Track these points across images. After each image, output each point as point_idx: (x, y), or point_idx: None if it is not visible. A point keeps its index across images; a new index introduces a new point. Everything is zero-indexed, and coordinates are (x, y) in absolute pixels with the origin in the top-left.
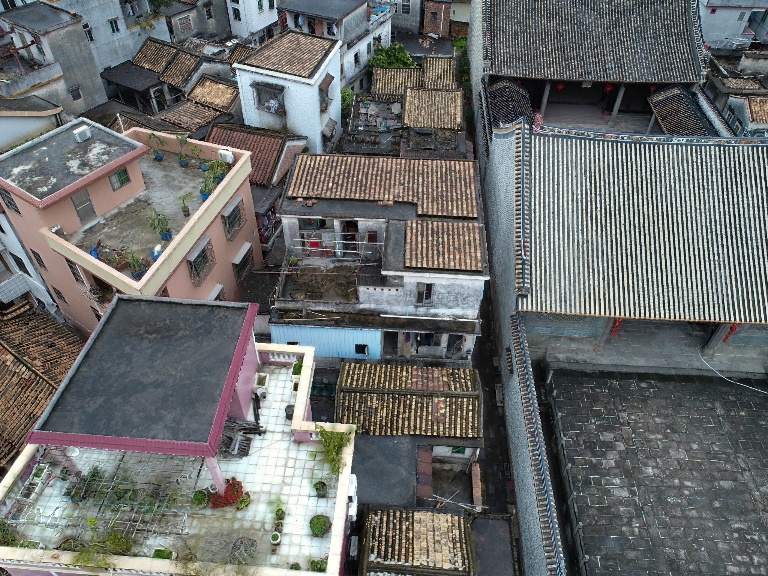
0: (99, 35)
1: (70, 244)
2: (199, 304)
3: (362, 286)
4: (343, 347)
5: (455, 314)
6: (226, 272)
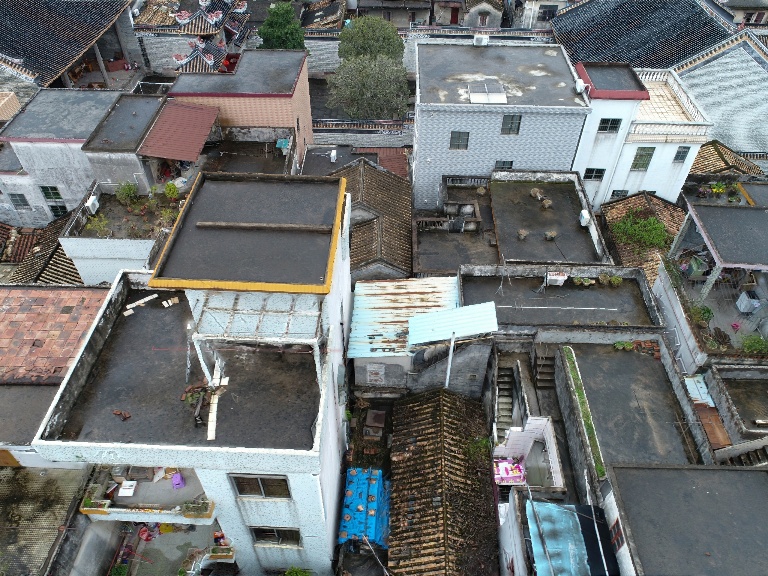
0: None
1: None
2: None
3: None
4: None
5: None
6: None
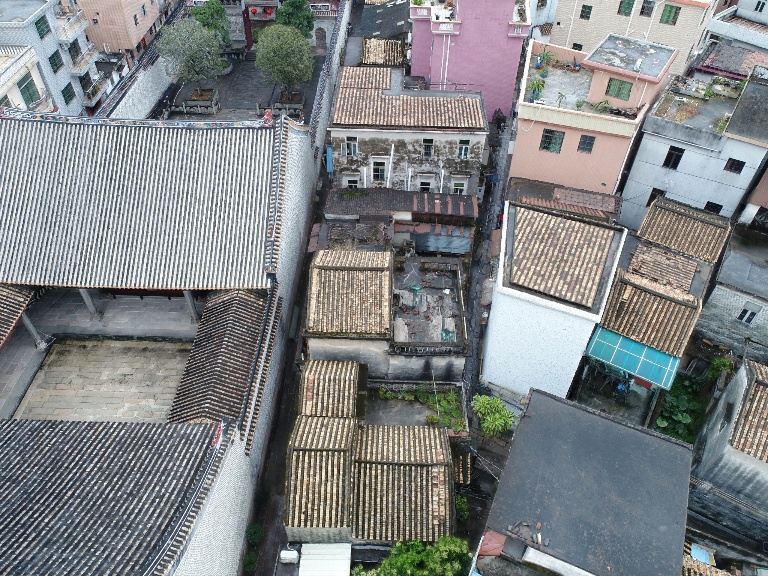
0: None
1: None
2: None
3: None
4: None
5: None
6: None
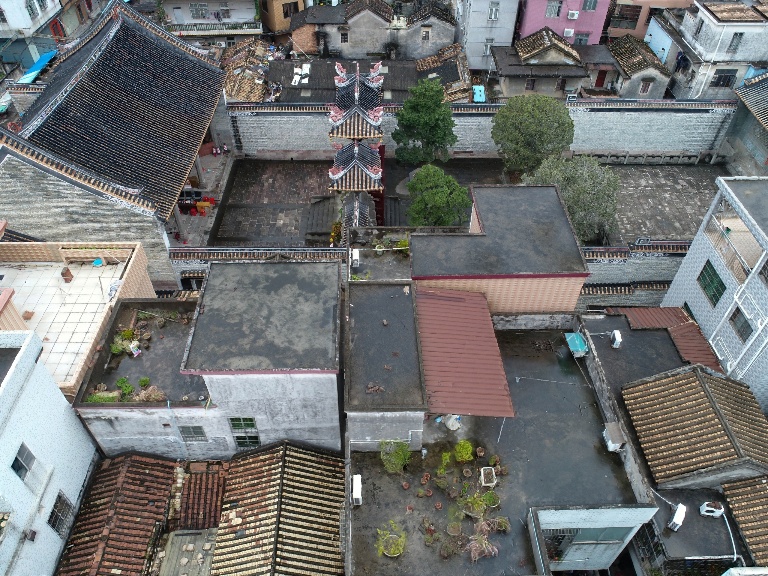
0: None
1: None
2: None
3: (687, 11)
4: (659, 48)
5: (700, 52)
6: None
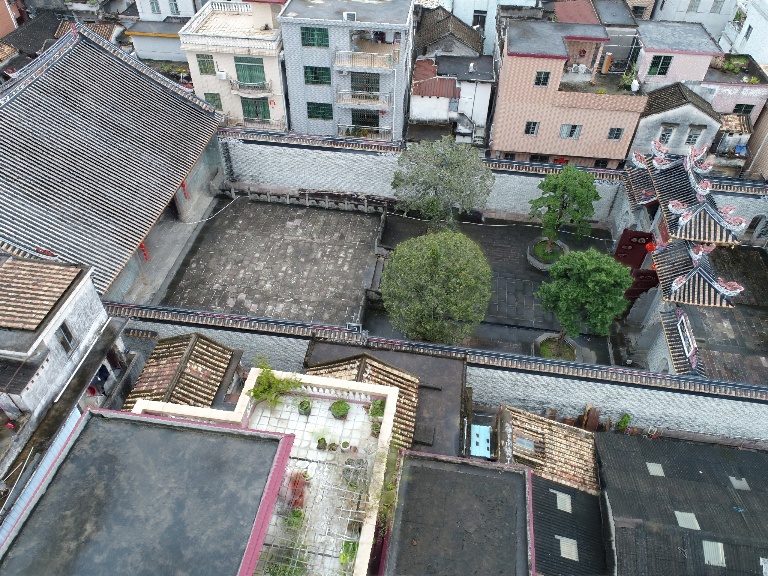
0: None
1: None
2: (55, 473)
3: (22, 392)
4: None
5: (95, 331)
6: None
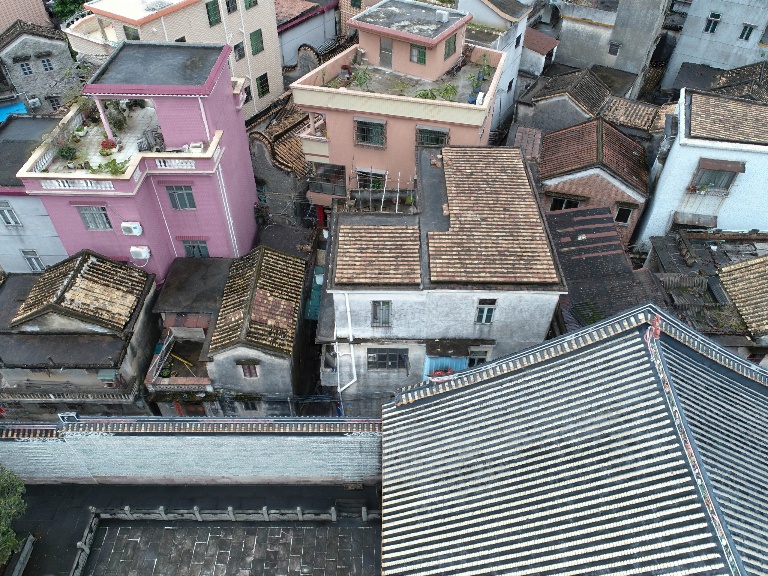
0: (723, 32)
1: (340, 56)
2: None
3: None
4: None
5: None
6: (404, 175)
